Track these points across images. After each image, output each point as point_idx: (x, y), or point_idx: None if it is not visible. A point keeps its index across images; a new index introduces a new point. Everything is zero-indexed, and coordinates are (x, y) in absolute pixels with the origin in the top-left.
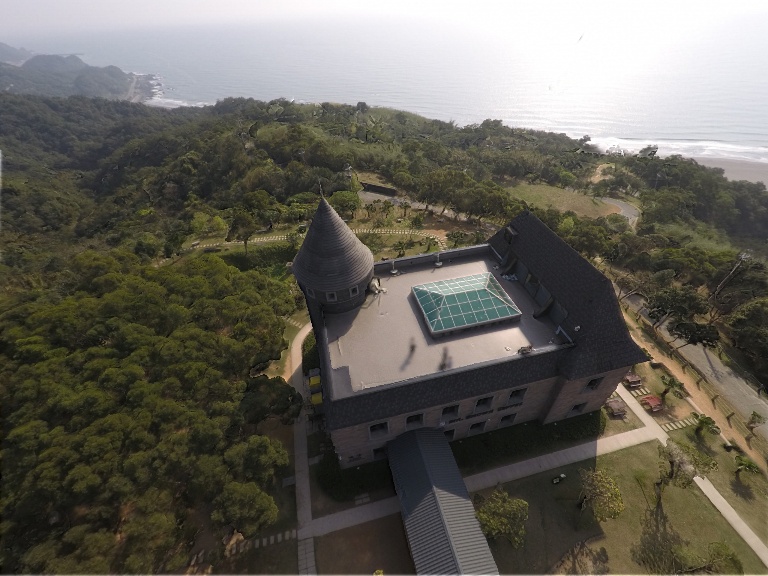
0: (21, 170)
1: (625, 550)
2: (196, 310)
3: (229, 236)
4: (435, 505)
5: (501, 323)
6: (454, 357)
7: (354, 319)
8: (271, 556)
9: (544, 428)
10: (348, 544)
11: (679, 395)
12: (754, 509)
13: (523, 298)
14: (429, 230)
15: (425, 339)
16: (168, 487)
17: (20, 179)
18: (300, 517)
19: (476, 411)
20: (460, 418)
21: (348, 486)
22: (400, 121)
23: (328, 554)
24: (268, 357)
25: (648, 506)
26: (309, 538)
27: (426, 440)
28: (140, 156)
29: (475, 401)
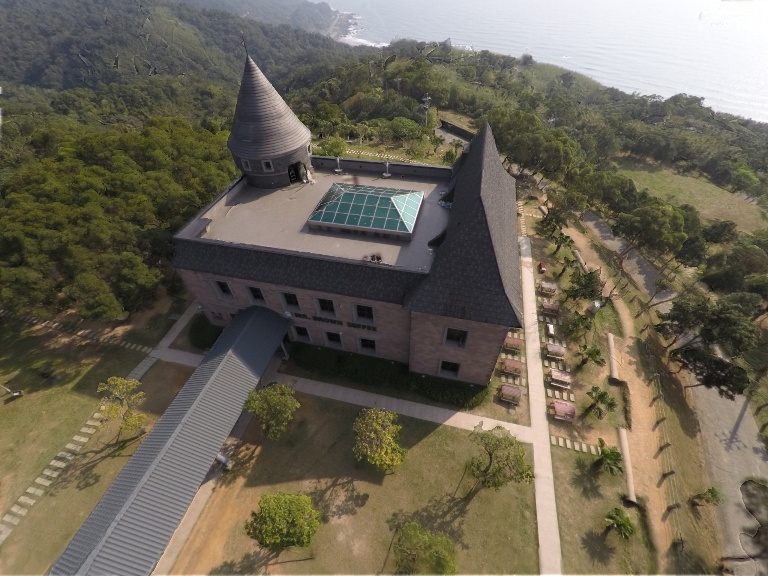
0: (221, 79)
1: (388, 510)
2: (177, 162)
3: None
4: (219, 363)
5: (386, 237)
6: (310, 248)
7: (265, 195)
8: (124, 355)
9: (408, 374)
10: (175, 375)
11: (598, 413)
12: (593, 573)
13: (438, 225)
14: None
15: (303, 227)
16: (59, 261)
17: (218, 85)
18: (162, 342)
19: (321, 314)
20: (307, 315)
21: (206, 337)
22: (564, 82)
23: (157, 374)
24: (197, 211)
25: (454, 492)
26: (156, 358)
27: (263, 319)
28: (303, 81)
29: (313, 298)
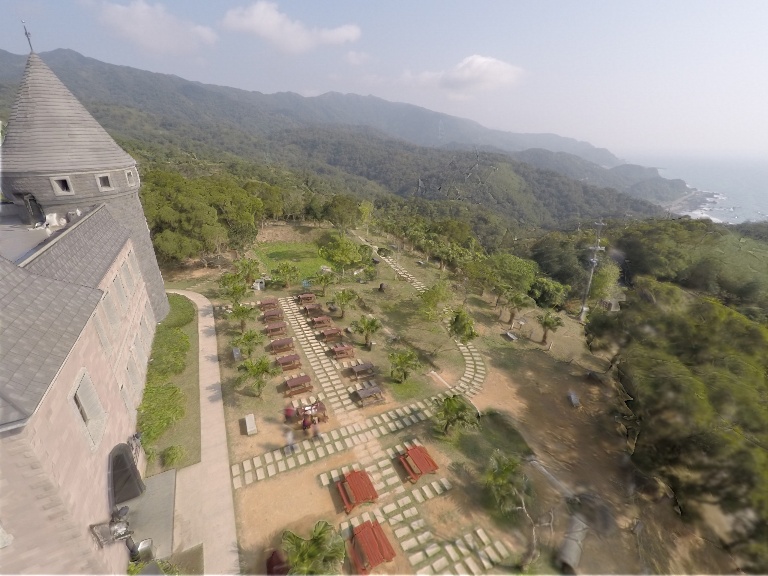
0: None
1: None
2: None
3: (325, 214)
4: None
5: None
6: None
7: None
8: None
9: None
10: None
11: None
12: None
13: None
14: (505, 383)
15: None
16: None
17: (498, 217)
18: None
19: None
20: None
21: None
22: None
23: None
24: None
25: None
26: None
27: None
28: None
29: None
